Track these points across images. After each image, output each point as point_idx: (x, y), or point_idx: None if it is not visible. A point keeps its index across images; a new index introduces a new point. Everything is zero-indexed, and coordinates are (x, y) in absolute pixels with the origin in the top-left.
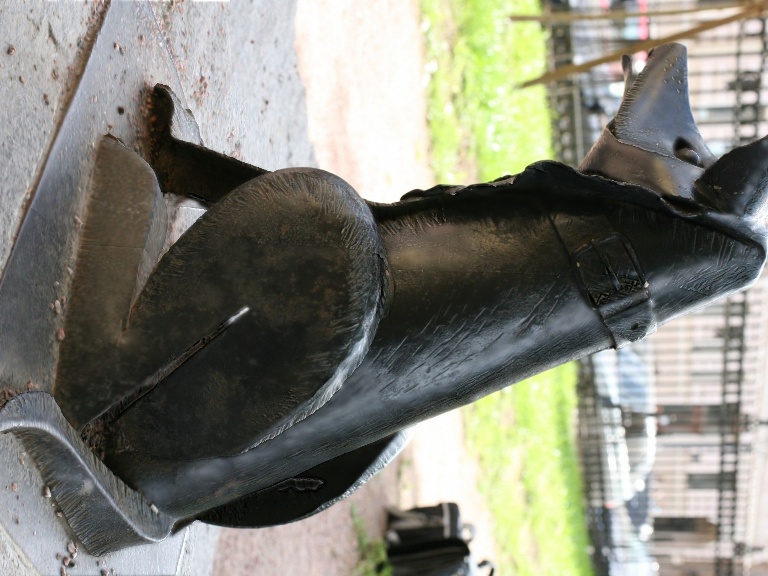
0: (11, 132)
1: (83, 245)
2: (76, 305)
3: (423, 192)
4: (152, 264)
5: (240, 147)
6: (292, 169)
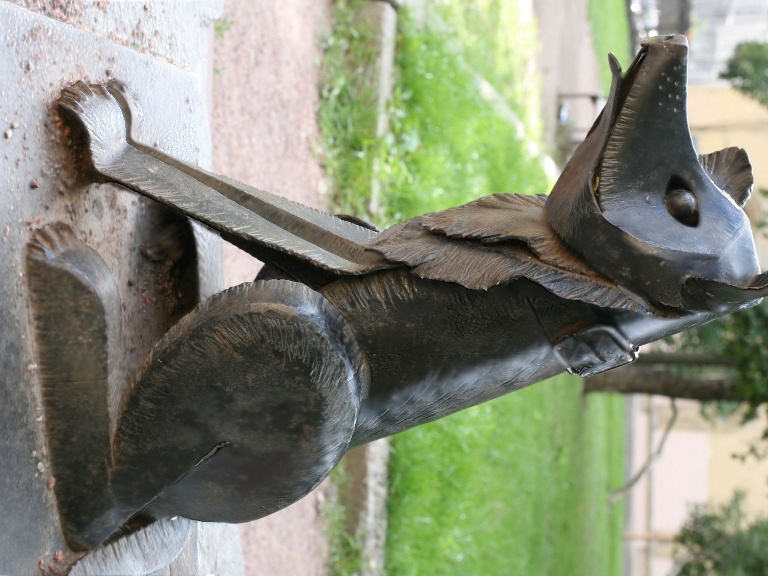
0: None
1: (44, 383)
2: (57, 448)
3: (389, 260)
4: (117, 364)
5: None
6: (246, 308)
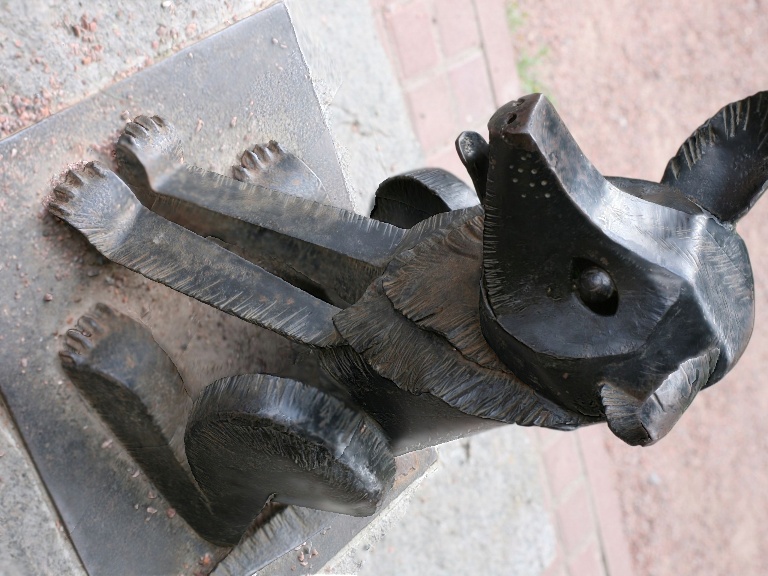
0: (7, 538)
1: (127, 449)
2: (162, 490)
3: None
4: (185, 417)
5: None
6: (216, 417)
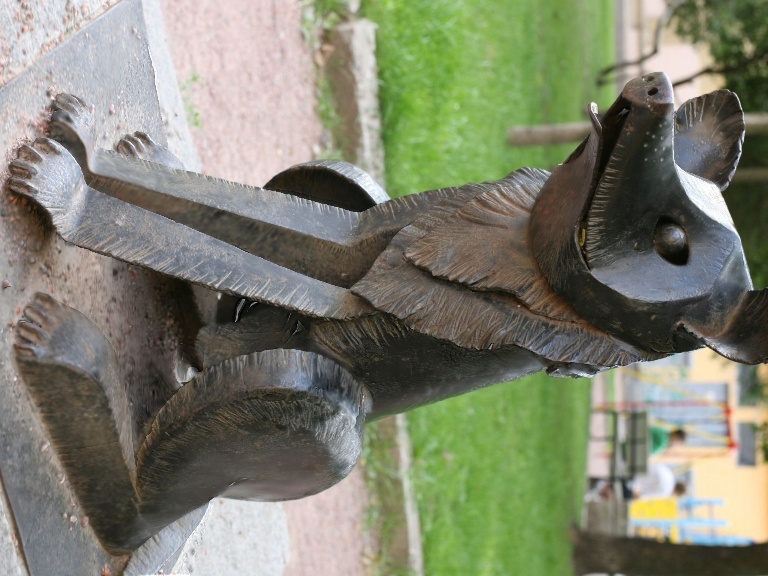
0: None
1: (60, 452)
2: (84, 496)
3: (377, 309)
4: (125, 413)
5: None
6: (244, 394)
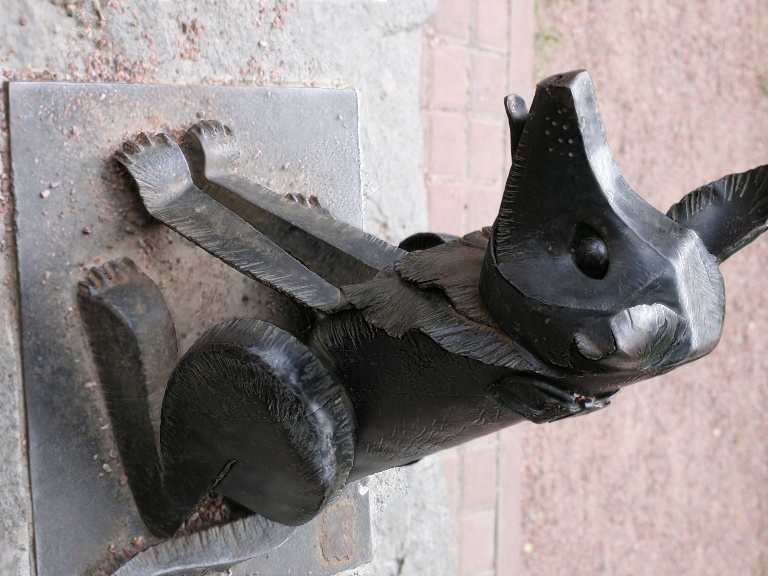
0: None
1: (106, 398)
2: (123, 452)
3: (349, 301)
4: None
5: (283, 0)
6: (210, 347)
